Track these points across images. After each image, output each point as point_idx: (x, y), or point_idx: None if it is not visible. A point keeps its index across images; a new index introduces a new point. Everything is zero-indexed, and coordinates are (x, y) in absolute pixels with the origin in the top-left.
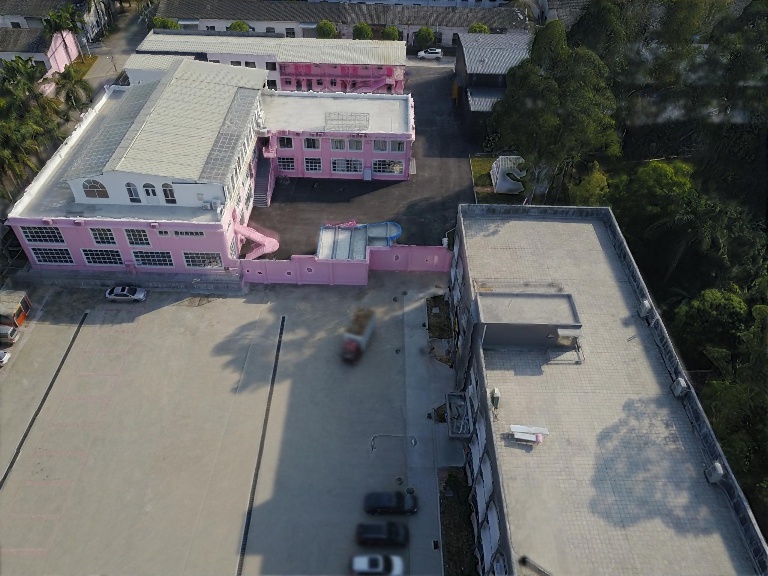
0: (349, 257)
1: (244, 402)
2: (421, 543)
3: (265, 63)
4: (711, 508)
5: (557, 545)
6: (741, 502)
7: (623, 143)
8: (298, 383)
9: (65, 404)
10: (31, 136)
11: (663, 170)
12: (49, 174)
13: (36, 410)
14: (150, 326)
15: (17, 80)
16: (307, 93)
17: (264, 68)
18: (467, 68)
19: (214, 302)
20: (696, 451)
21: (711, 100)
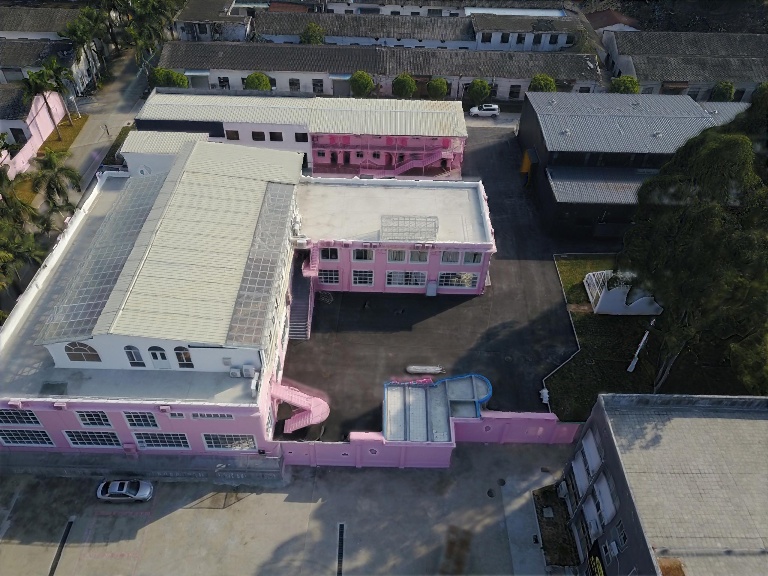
0: (428, 438)
1: None
2: None
3: (294, 134)
4: None
5: None
6: None
7: None
8: None
9: None
10: None
11: None
12: (21, 316)
13: None
14: (159, 546)
15: None
16: (351, 180)
17: (293, 139)
18: (547, 144)
19: (245, 501)
20: None
21: None
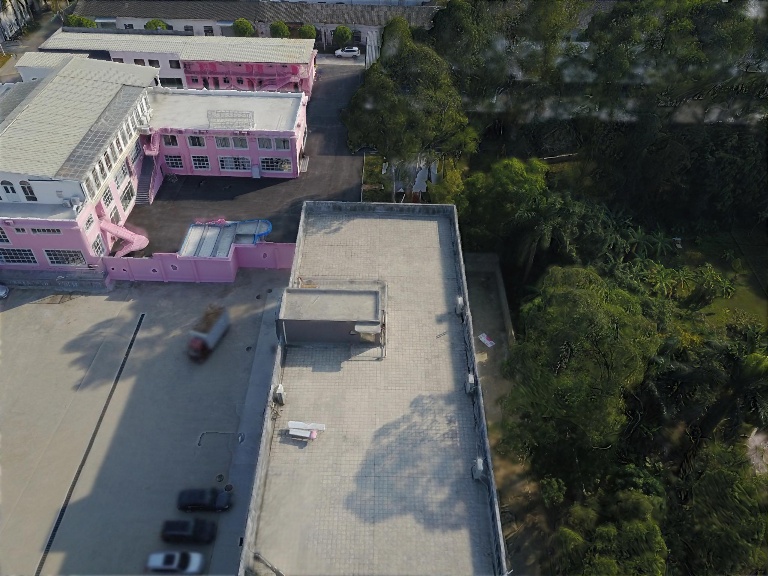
0: (211, 254)
1: (83, 399)
2: (227, 540)
3: (168, 61)
4: (468, 504)
5: (301, 541)
6: (492, 498)
7: (480, 140)
8: (142, 380)
9: None
10: None
11: (513, 167)
12: None
13: None
14: (6, 323)
15: None
16: (201, 91)
17: (168, 66)
18: (366, 66)
19: (76, 299)
20: (471, 447)
21: (575, 98)
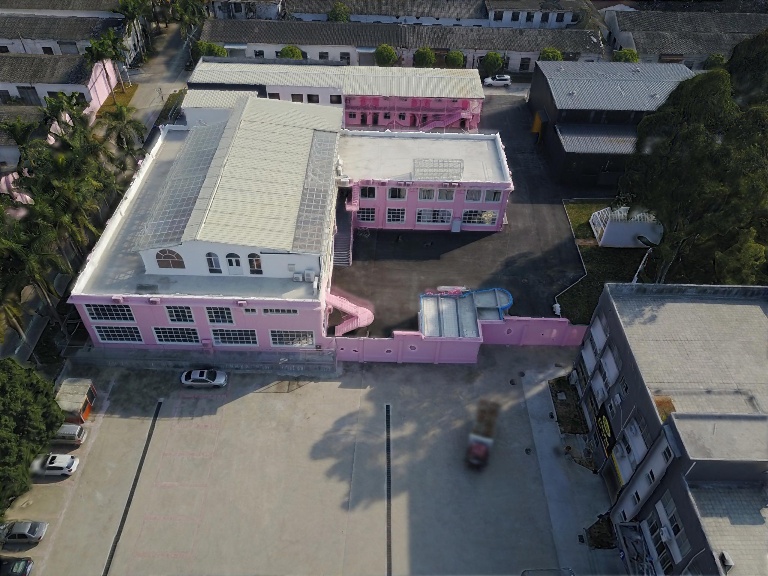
0: (460, 334)
1: (359, 521)
2: None
3: (329, 96)
4: None
5: None
6: None
7: None
8: (419, 494)
9: (149, 526)
10: (92, 195)
11: None
12: (110, 236)
13: (116, 534)
14: (236, 419)
15: (63, 121)
16: (384, 133)
17: (328, 101)
18: (556, 103)
19: (306, 387)
20: None
21: None
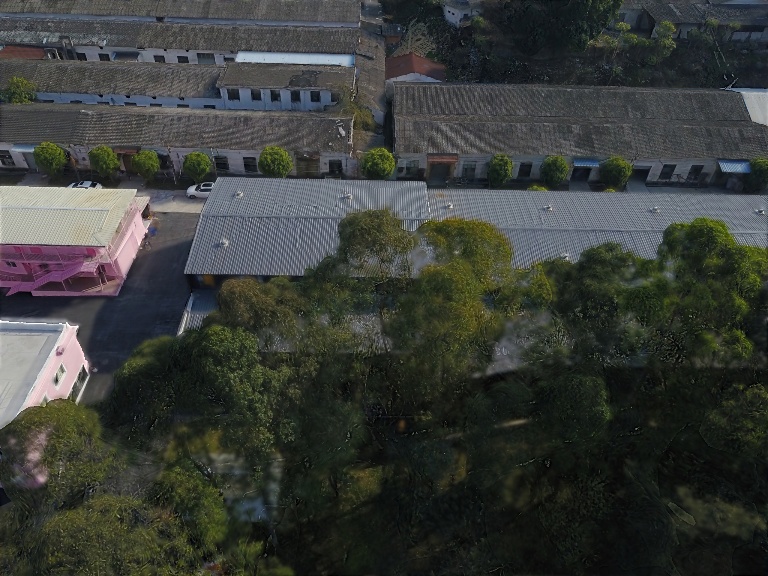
0: None
1: None
2: None
3: None
4: None
5: None
6: None
7: None
8: None
9: None
10: None
11: None
12: None
13: None
14: None
15: None
16: None
17: None
18: (187, 263)
19: None
20: None
21: (499, 466)
